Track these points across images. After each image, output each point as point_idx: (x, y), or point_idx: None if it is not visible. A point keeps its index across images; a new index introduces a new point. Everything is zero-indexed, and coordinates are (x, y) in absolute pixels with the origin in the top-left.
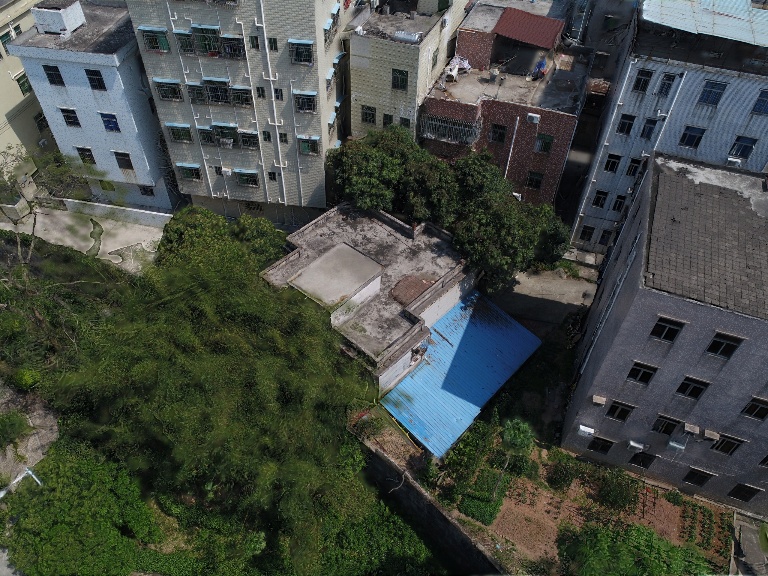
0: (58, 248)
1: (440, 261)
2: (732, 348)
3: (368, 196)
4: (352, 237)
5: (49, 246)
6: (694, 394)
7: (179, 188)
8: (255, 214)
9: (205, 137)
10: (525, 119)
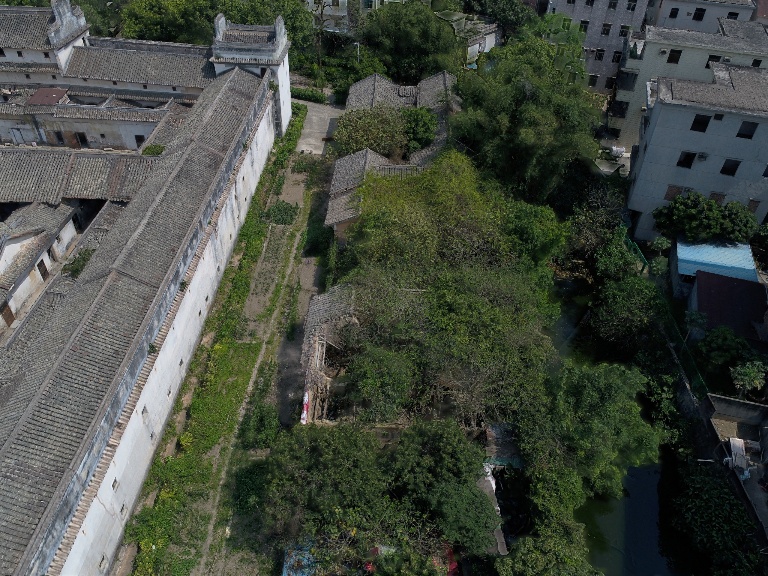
0: (315, 29)
1: (486, 25)
2: (593, 1)
3: (453, 5)
4: None
5: None
6: (585, 30)
7: (360, 14)
8: None
9: None
10: None
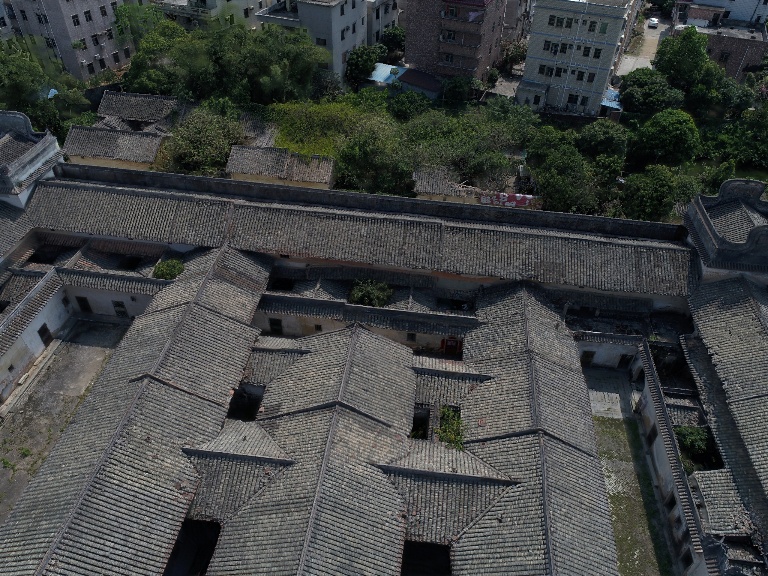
0: None
1: None
2: None
3: None
4: None
5: None
6: (90, 19)
7: None
8: None
9: None
10: None
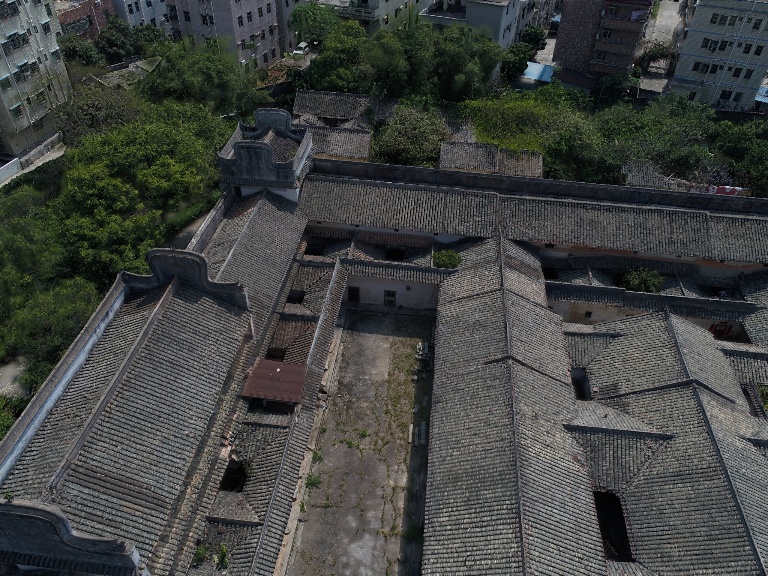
0: (40, 167)
1: None
2: None
3: None
4: (116, 78)
5: (34, 172)
6: None
7: (15, 129)
8: (41, 133)
9: (18, 77)
10: (95, 6)
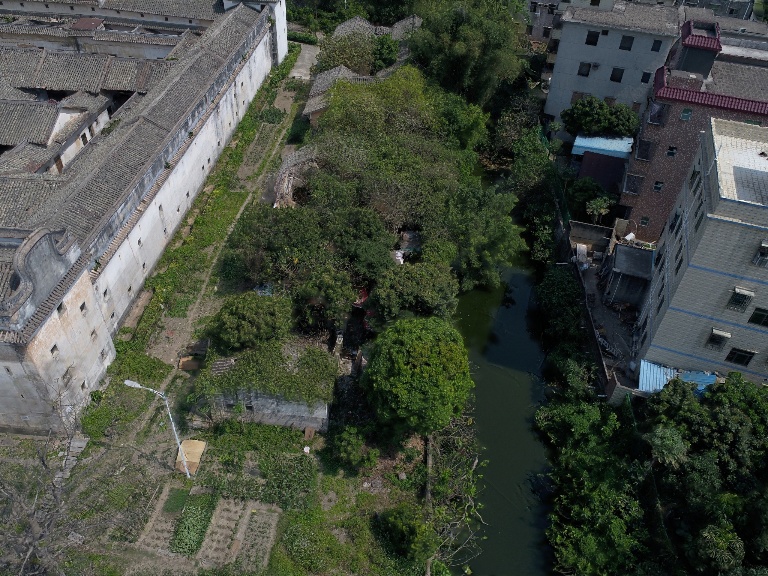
0: None
1: None
2: None
3: None
4: None
5: None
6: None
7: None
8: None
9: None
10: None
